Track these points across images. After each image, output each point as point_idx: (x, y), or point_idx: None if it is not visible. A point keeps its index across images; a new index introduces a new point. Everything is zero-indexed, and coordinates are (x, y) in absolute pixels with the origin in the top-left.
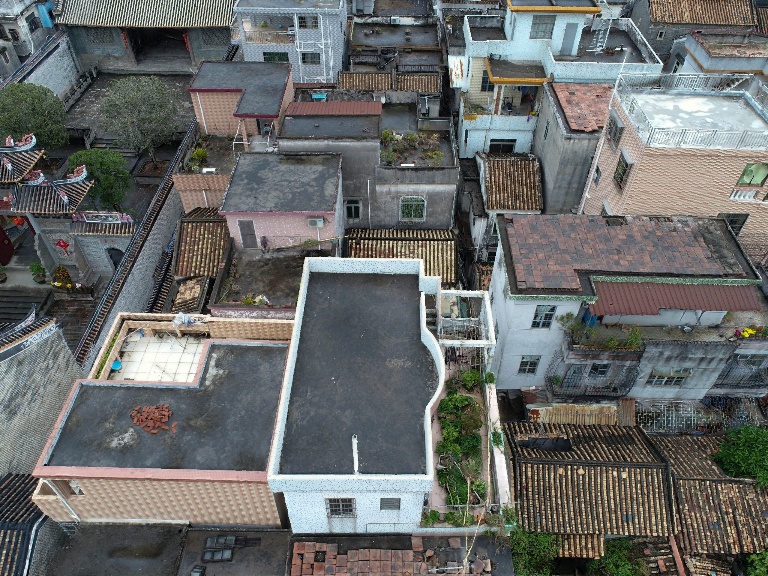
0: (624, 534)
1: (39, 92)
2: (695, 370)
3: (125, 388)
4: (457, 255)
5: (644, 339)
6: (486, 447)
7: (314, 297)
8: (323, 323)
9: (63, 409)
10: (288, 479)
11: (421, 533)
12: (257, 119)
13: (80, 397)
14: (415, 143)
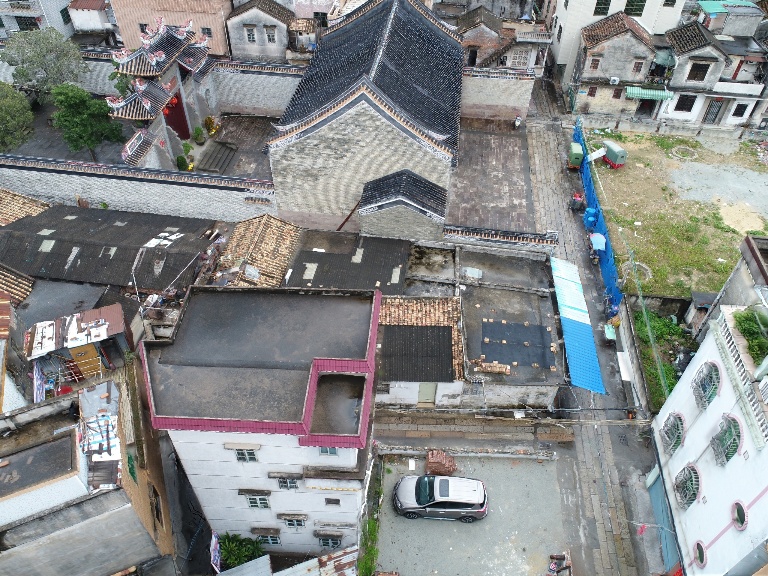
0: None
1: None
2: None
3: None
4: None
5: None
6: None
7: None
8: None
9: None
10: None
11: None
12: None
13: None
14: None
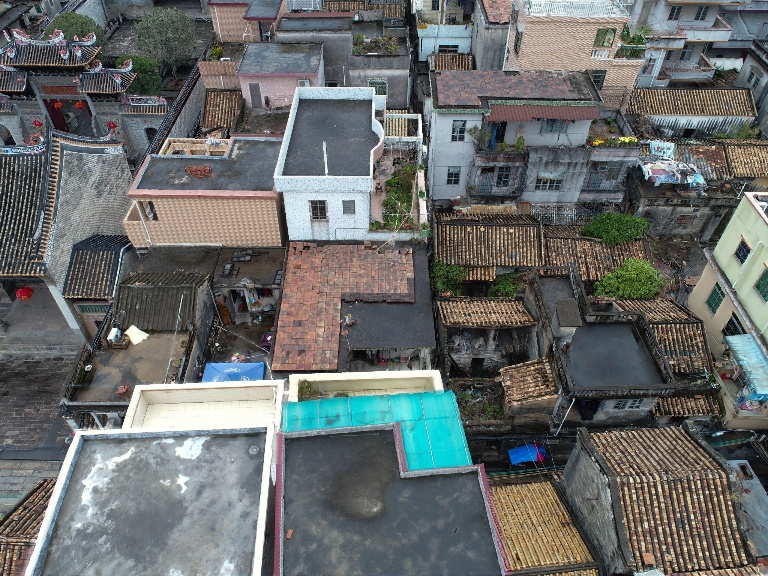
0: (509, 265)
1: (86, 19)
2: (567, 174)
3: (180, 159)
4: (409, 119)
5: (528, 147)
6: (416, 203)
7: (302, 110)
8: (308, 122)
9: (142, 167)
10: (286, 177)
11: (370, 240)
12: (260, 29)
13: (151, 163)
14: (380, 44)
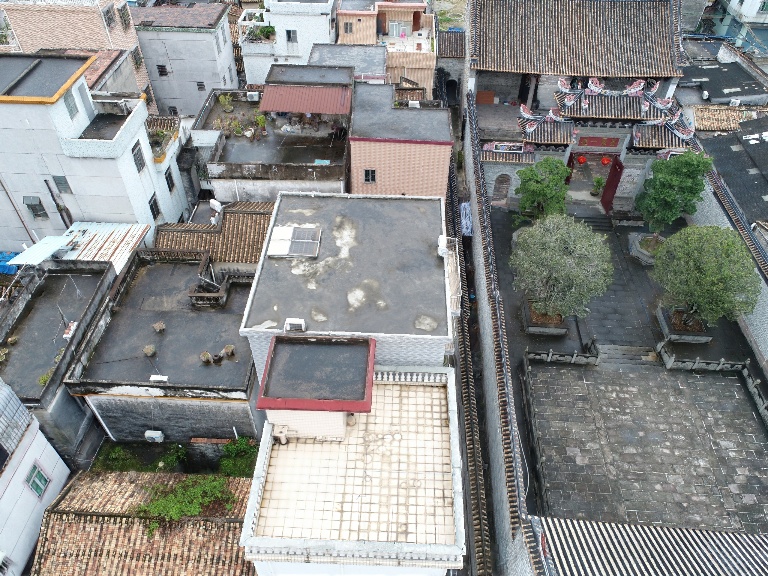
0: None
1: (698, 251)
2: None
3: None
4: None
5: None
6: None
7: None
8: (322, 0)
9: None
10: None
11: None
12: None
13: None
14: None
